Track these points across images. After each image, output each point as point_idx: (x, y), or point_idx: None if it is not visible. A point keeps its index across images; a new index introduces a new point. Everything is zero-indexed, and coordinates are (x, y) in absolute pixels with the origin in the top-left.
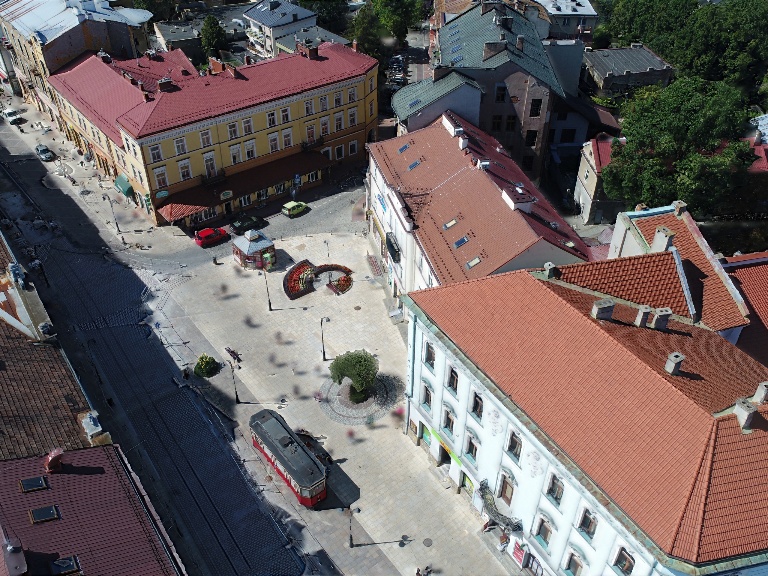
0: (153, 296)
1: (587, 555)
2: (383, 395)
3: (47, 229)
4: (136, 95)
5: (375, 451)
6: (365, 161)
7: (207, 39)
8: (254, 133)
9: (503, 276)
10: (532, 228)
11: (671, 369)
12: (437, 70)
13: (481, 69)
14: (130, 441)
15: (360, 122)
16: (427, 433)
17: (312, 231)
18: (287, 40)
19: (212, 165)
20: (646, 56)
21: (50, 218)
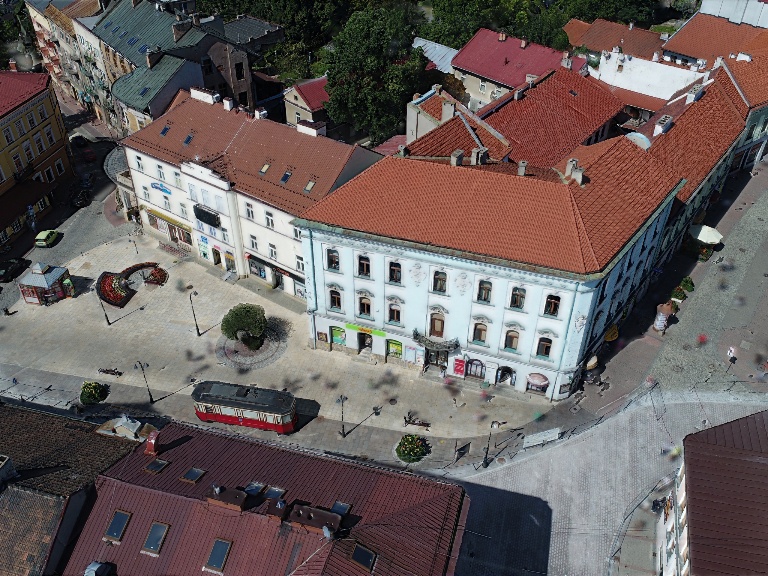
0: None
1: (522, 322)
2: (273, 334)
3: None
4: None
5: (303, 371)
6: (75, 178)
7: None
8: None
9: (374, 168)
10: (342, 142)
11: (523, 172)
12: (150, 57)
13: (186, 47)
14: None
15: (57, 139)
16: (338, 334)
17: (84, 250)
18: None
19: None
20: (255, 23)
21: None
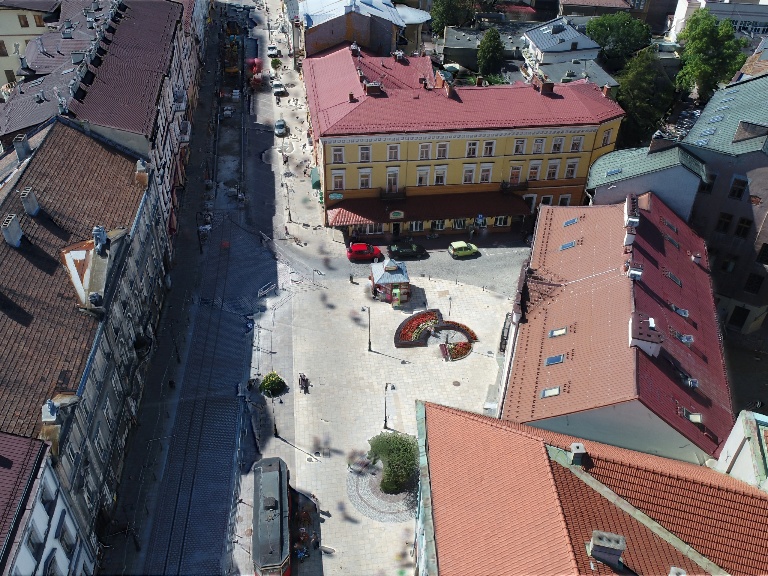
0: (276, 294)
1: None
2: None
3: (237, 199)
4: (357, 93)
5: (368, 557)
6: None
7: (483, 52)
8: (448, 159)
9: (517, 434)
10: (636, 379)
11: None
12: (656, 140)
13: (717, 152)
14: (162, 430)
15: (580, 176)
16: None
17: (466, 280)
18: (551, 68)
19: (395, 180)
20: None
21: (245, 189)
